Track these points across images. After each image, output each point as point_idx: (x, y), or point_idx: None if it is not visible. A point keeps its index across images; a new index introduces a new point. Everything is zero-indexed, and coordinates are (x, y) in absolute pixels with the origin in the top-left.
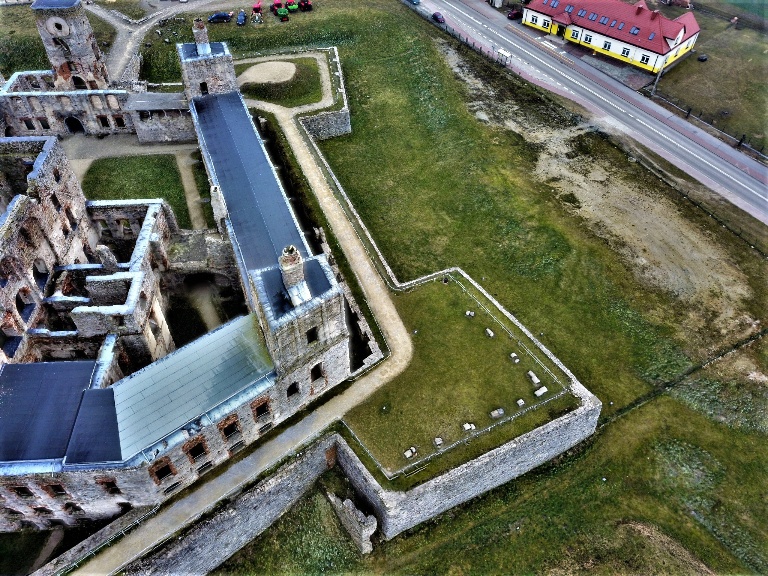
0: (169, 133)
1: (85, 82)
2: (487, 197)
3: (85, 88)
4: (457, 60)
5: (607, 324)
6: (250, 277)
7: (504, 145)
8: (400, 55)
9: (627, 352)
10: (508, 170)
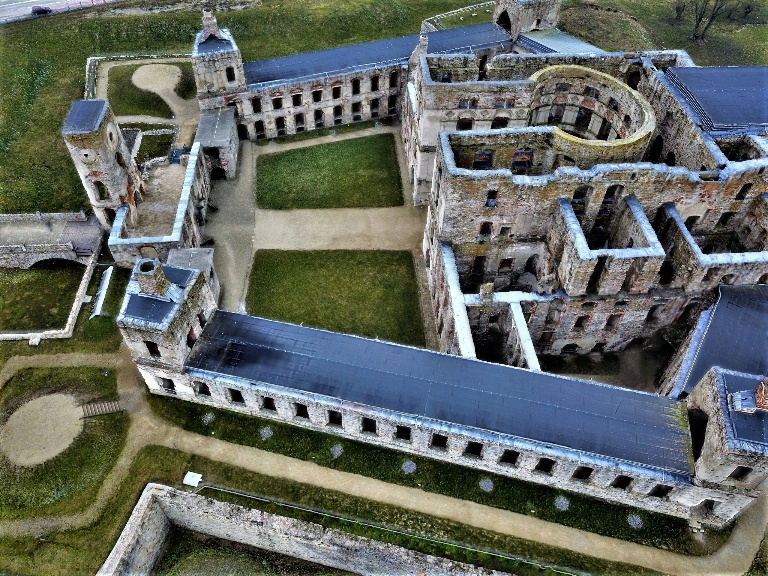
0: (235, 149)
1: (139, 193)
2: (338, 18)
3: (136, 205)
4: (137, 10)
5: (442, 3)
6: (524, 4)
7: (282, 3)
8: (96, 42)
9: (459, 2)
10: (312, 6)
